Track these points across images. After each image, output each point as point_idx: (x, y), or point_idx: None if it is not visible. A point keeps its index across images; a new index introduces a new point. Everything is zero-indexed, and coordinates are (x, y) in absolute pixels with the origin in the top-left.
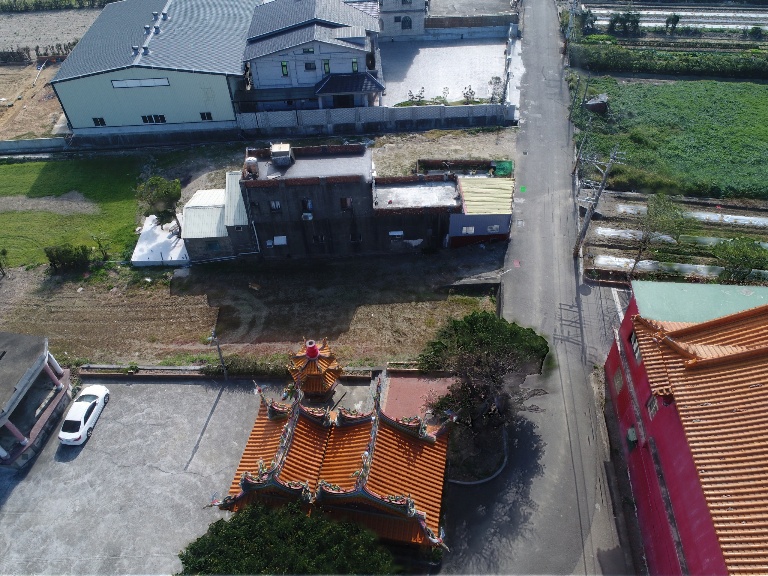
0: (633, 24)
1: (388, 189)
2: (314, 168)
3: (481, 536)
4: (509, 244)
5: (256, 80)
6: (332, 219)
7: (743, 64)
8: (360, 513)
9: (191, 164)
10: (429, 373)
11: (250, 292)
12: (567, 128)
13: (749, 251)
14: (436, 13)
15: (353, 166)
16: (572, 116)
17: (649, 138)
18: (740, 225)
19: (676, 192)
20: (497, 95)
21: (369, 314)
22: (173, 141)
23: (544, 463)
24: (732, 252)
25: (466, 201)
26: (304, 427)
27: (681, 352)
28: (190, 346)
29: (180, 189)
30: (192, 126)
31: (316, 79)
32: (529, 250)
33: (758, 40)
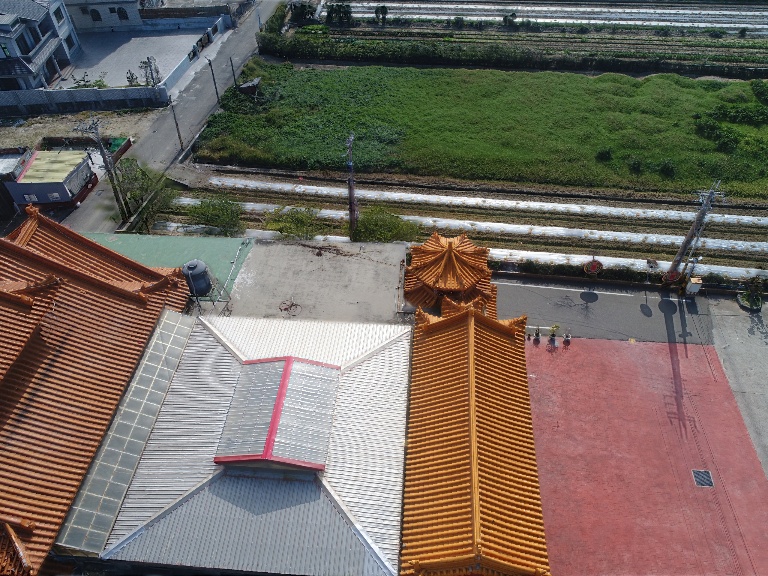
0: (346, 15)
1: None
2: None
3: None
4: (74, 211)
5: None
6: None
7: (414, 51)
8: None
9: None
10: None
11: None
12: (210, 109)
13: (210, 210)
14: (172, 5)
15: None
16: (221, 98)
17: (279, 118)
18: (305, 194)
19: (269, 165)
20: None
21: None
22: None
23: None
24: (194, 211)
25: (28, 171)
26: None
27: None
28: None
29: None
30: None
31: None
32: (87, 216)
33: (459, 29)
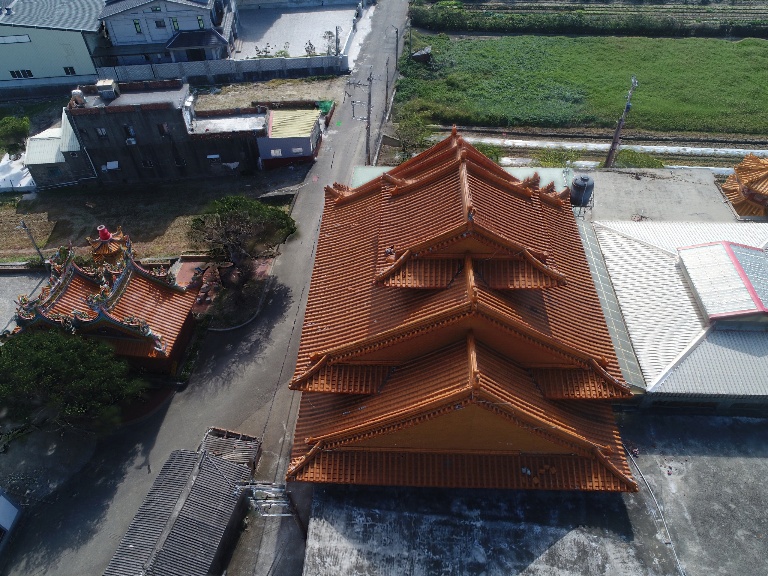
0: None
1: (209, 120)
2: (135, 100)
3: (223, 364)
4: (313, 165)
5: (113, 37)
6: (154, 144)
7: (560, 21)
8: (111, 338)
9: (53, 111)
10: (215, 258)
11: (86, 209)
12: (392, 75)
13: None
14: None
15: (169, 97)
16: (399, 65)
17: (461, 82)
18: (516, 147)
19: (471, 123)
20: (332, 48)
21: (184, 222)
22: (42, 95)
23: (288, 314)
24: None
25: (273, 128)
26: (79, 283)
27: (336, 195)
28: (25, 250)
29: (27, 125)
30: (58, 80)
31: (168, 36)
32: (329, 168)
33: (586, 3)
